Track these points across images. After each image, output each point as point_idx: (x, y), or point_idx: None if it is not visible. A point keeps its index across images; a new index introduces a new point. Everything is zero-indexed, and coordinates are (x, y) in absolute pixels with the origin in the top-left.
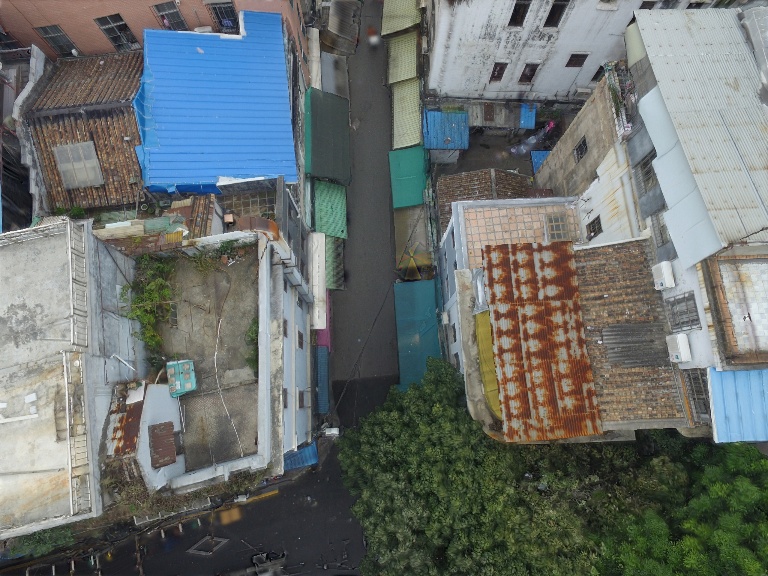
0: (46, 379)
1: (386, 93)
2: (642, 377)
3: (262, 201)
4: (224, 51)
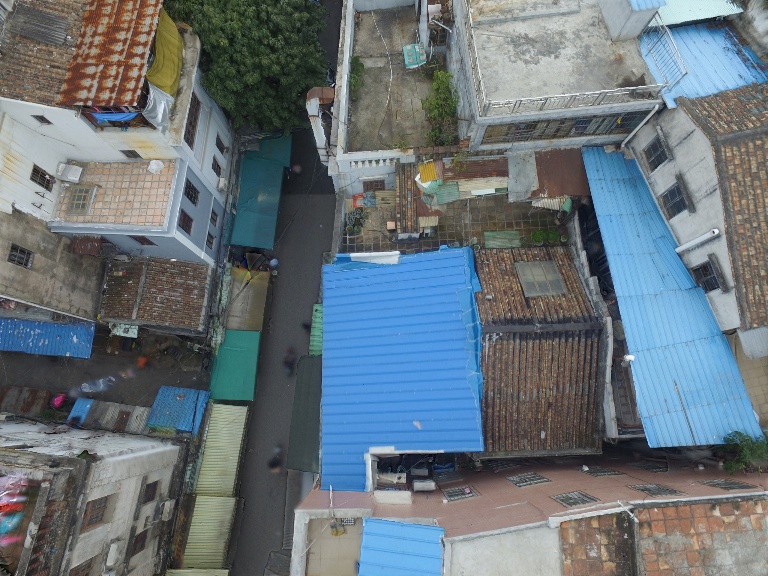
0: (496, 6)
1: (248, 511)
2: (46, 5)
3: (361, 249)
4: (391, 428)
